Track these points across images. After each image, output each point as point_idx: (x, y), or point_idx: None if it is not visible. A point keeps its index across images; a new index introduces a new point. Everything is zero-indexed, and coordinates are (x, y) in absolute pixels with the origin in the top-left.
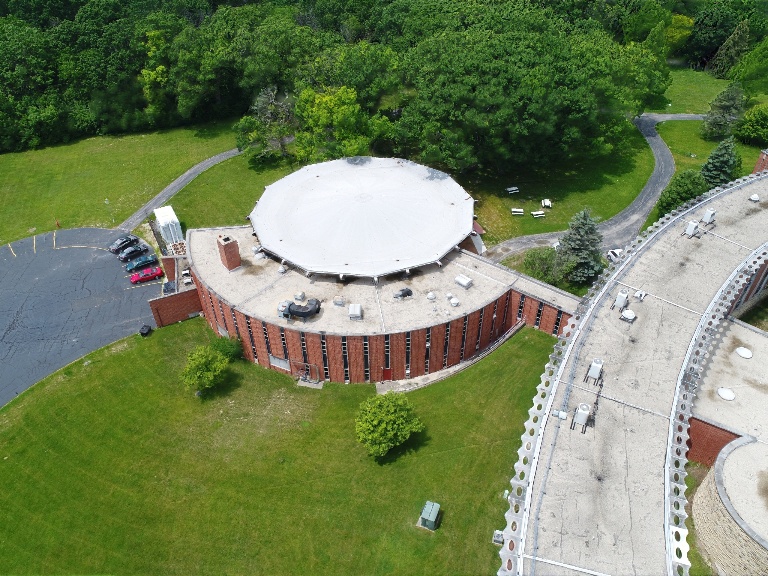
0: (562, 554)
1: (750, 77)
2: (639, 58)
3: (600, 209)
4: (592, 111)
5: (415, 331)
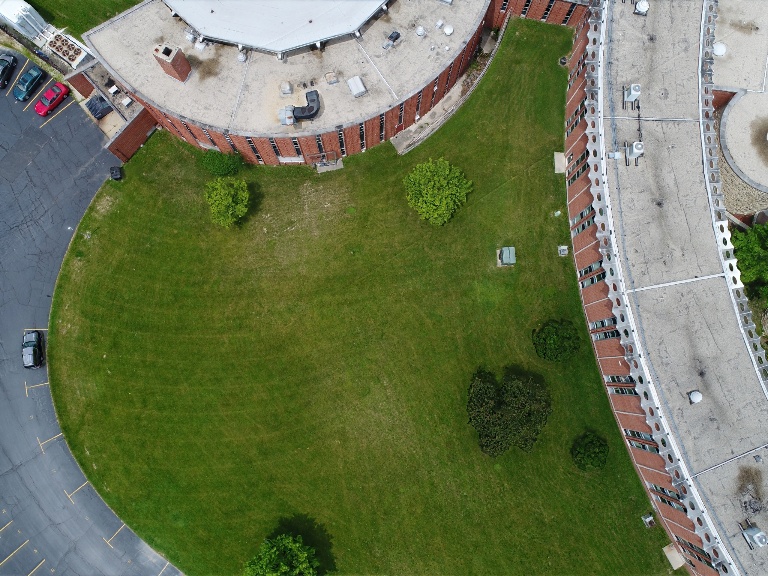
0: (651, 279)
1: None
2: None
3: None
4: None
5: (426, 86)
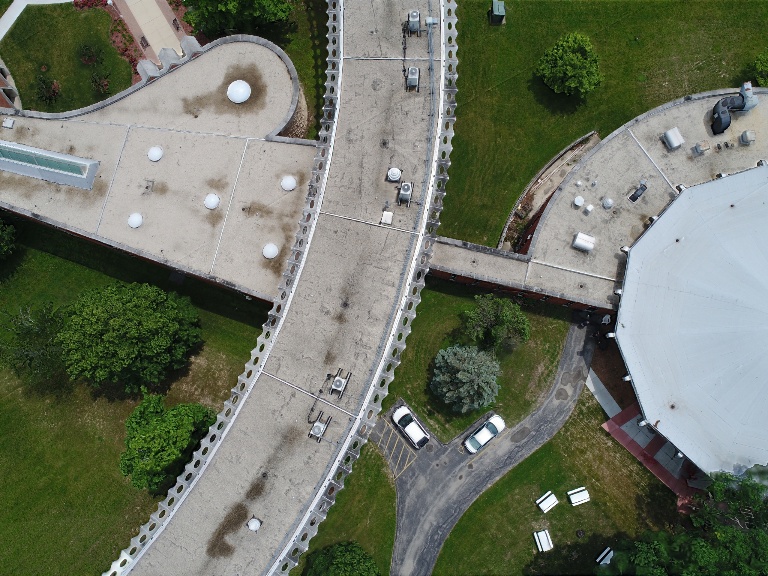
0: None
1: None
2: None
3: (462, 569)
4: None
5: None
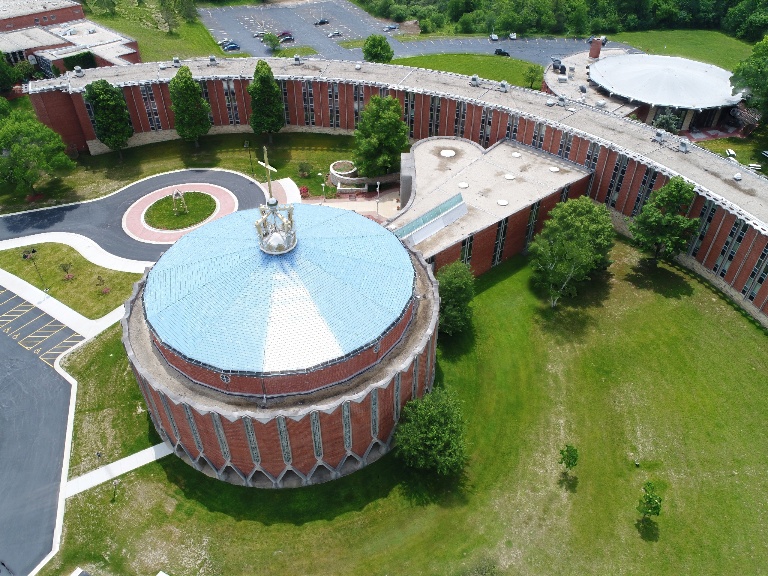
0: None
1: None
2: None
3: None
4: None
5: None
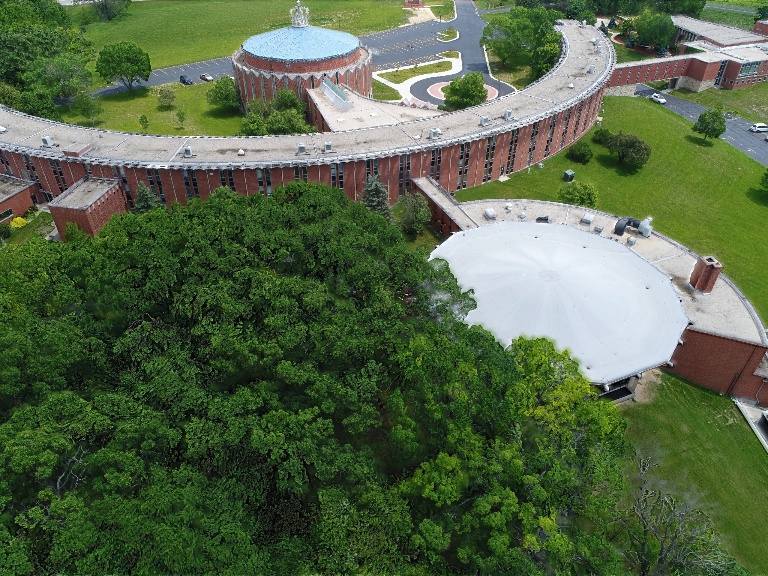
0: None
1: None
2: None
3: None
4: None
5: None
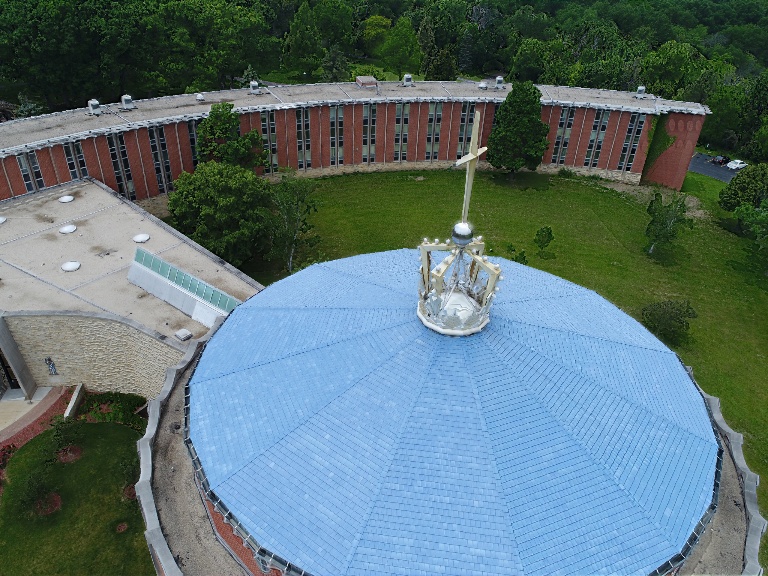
0: None
1: (385, 53)
2: (237, 18)
3: None
4: (119, 38)
5: None
